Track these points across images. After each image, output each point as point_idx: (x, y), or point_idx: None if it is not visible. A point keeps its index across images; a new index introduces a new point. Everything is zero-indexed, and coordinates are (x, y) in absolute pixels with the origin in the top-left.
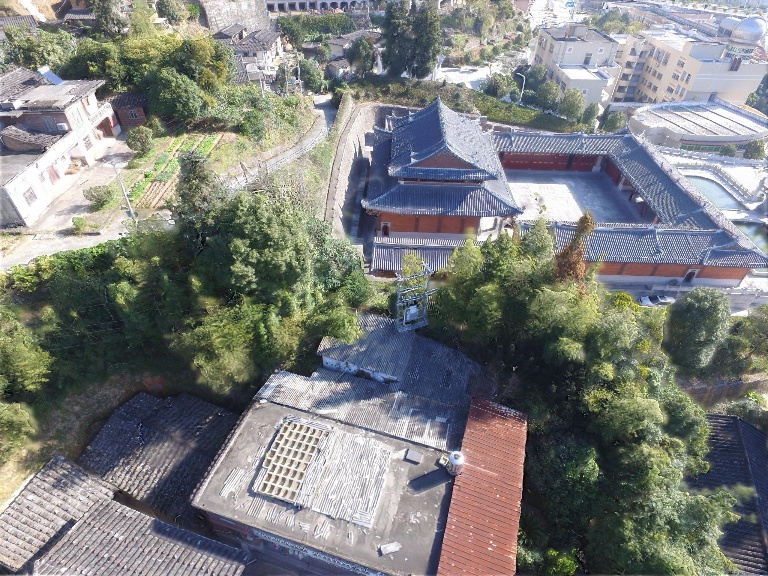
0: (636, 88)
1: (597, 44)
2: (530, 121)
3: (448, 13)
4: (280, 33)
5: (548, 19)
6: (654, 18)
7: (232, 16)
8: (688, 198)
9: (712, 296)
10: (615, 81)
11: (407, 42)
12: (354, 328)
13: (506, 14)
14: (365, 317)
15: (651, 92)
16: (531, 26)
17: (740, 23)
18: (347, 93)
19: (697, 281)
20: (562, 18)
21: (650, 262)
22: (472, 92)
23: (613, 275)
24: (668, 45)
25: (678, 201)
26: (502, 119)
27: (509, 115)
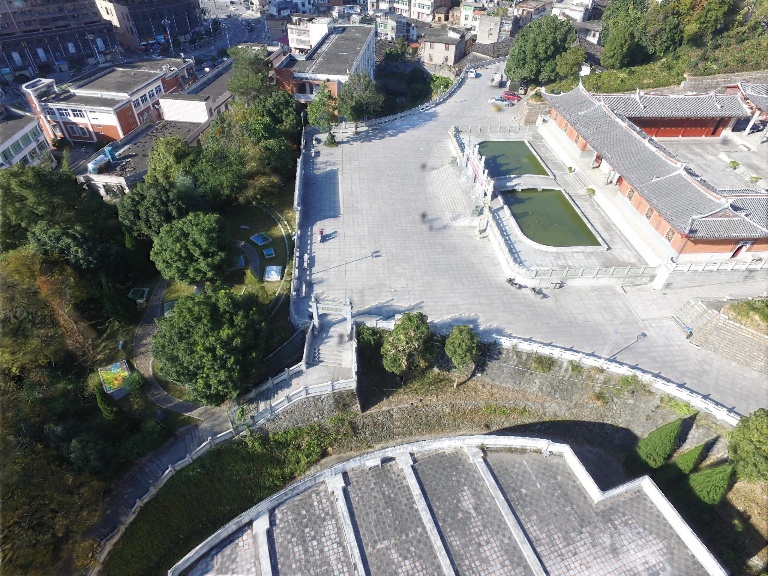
0: None
1: None
2: None
3: None
4: None
5: None
6: None
7: None
8: None
9: None
10: None
11: None
12: (757, 3)
13: None
14: (761, 25)
15: None
16: None
17: None
18: None
19: None
20: None
21: None
22: None
23: None
24: None
25: None
26: None
27: None
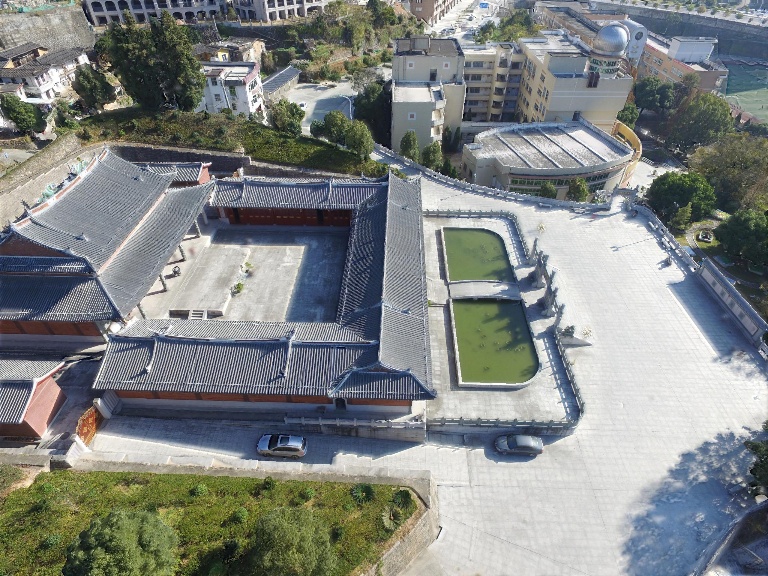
0: (516, 102)
1: (440, 58)
2: (305, 160)
3: (308, 22)
4: (82, 52)
5: (461, 22)
6: (560, 20)
7: (38, 32)
8: (380, 284)
9: (100, 539)
10: (462, 100)
11: (150, 69)
12: None
13: (389, 20)
14: None
15: (525, 108)
16: (425, 32)
17: (599, 32)
18: (68, 133)
19: (353, 407)
20: (478, 20)
21: (262, 393)
22: (243, 125)
23: (239, 401)
24: (535, 56)
25: (369, 287)
26: (271, 158)
27: (280, 153)
